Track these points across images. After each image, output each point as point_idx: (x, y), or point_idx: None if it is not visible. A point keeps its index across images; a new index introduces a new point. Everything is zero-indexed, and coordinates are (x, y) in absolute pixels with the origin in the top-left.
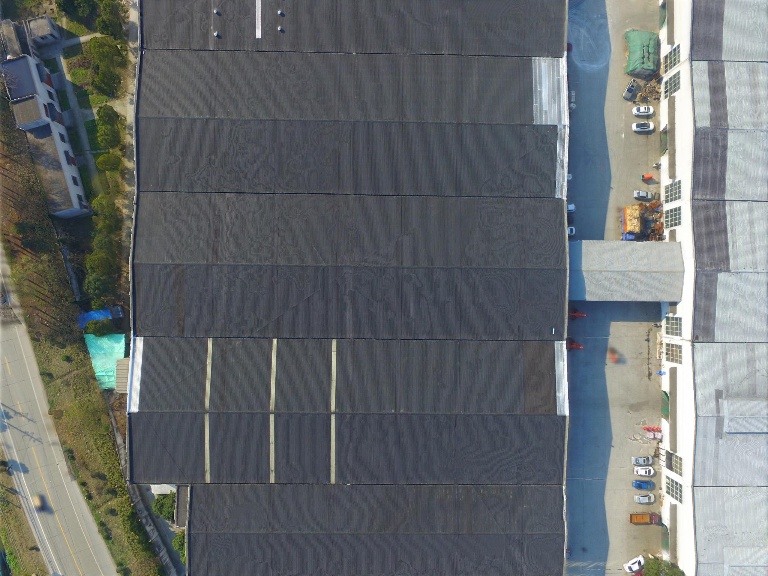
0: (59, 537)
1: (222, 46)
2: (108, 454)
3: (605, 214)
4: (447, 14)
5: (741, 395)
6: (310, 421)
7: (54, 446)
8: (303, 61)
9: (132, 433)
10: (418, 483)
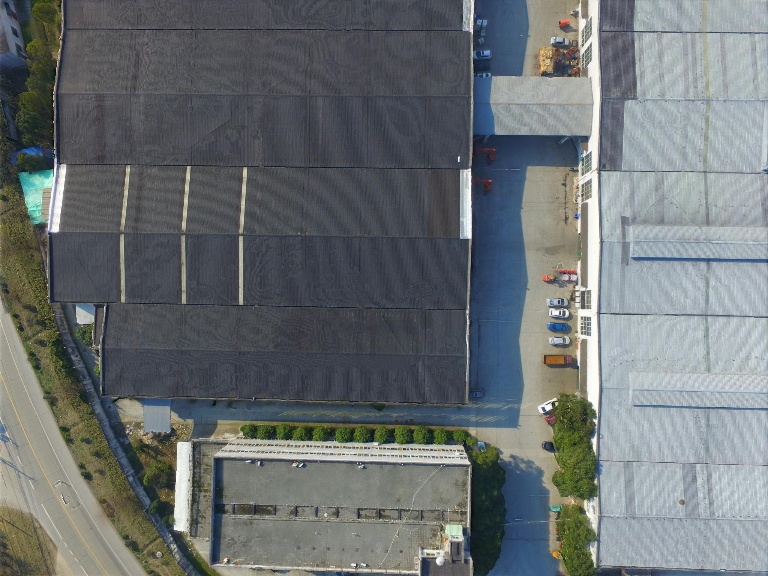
0: None
1: None
2: (39, 288)
3: (522, 61)
4: None
5: (648, 222)
6: (220, 243)
7: None
8: None
9: (53, 253)
10: (324, 306)
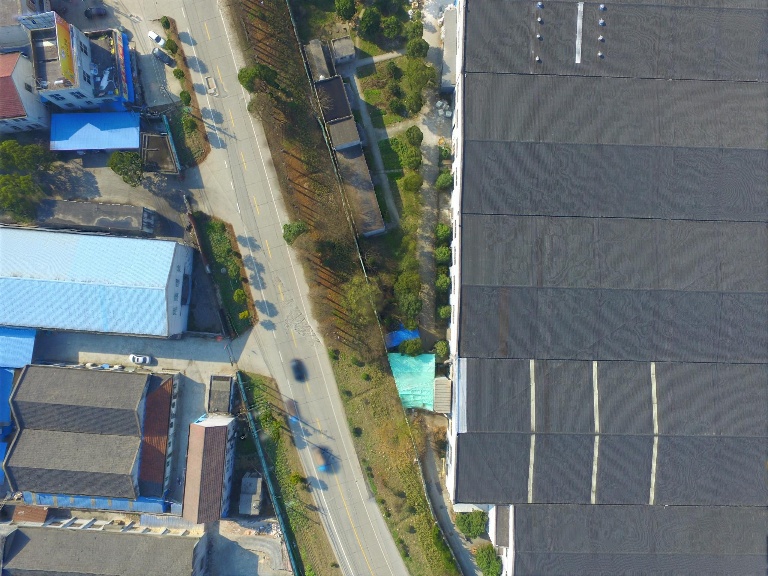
0: (358, 554)
1: (542, 70)
2: (407, 472)
3: None
4: (761, 42)
5: None
6: (631, 443)
7: (352, 463)
8: (621, 86)
9: (459, 453)
10: (734, 505)
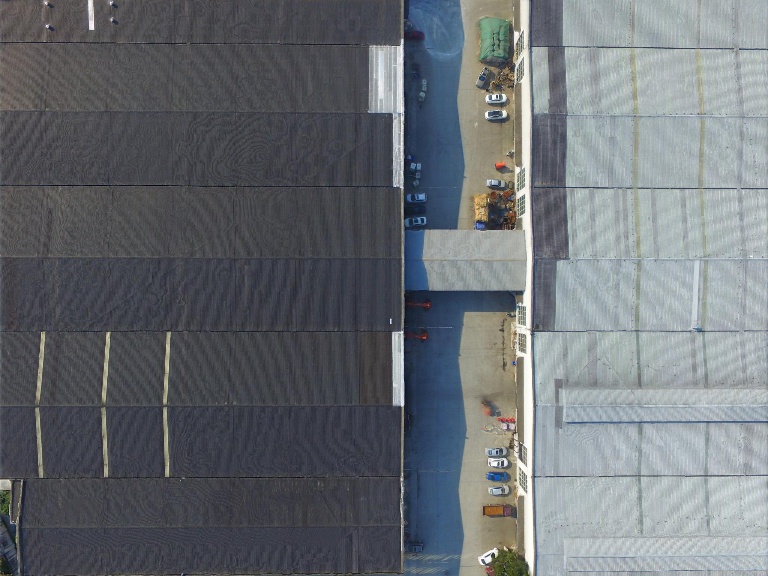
0: None
1: (55, 38)
2: None
3: (458, 203)
4: (282, 3)
5: (581, 384)
6: (143, 414)
7: None
8: (137, 52)
9: None
10: (254, 476)
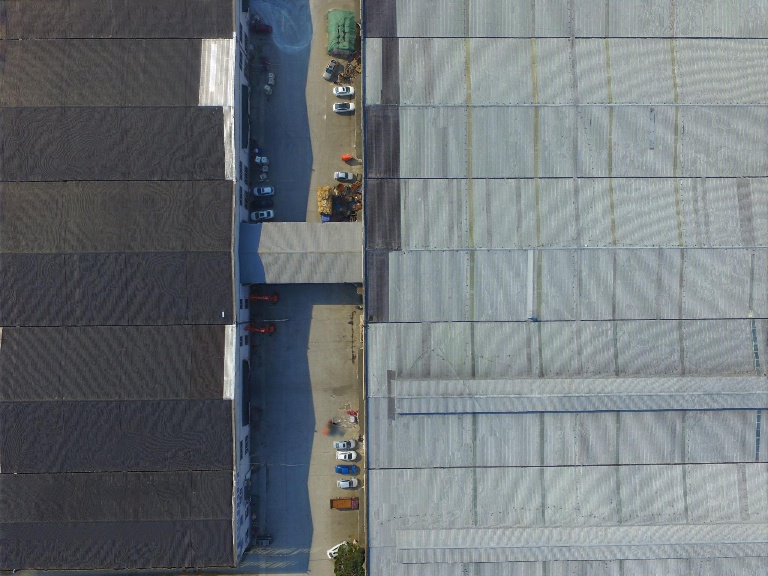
0: None
1: None
2: None
3: (307, 196)
4: None
5: (414, 375)
6: None
7: None
8: None
9: None
10: (86, 471)
